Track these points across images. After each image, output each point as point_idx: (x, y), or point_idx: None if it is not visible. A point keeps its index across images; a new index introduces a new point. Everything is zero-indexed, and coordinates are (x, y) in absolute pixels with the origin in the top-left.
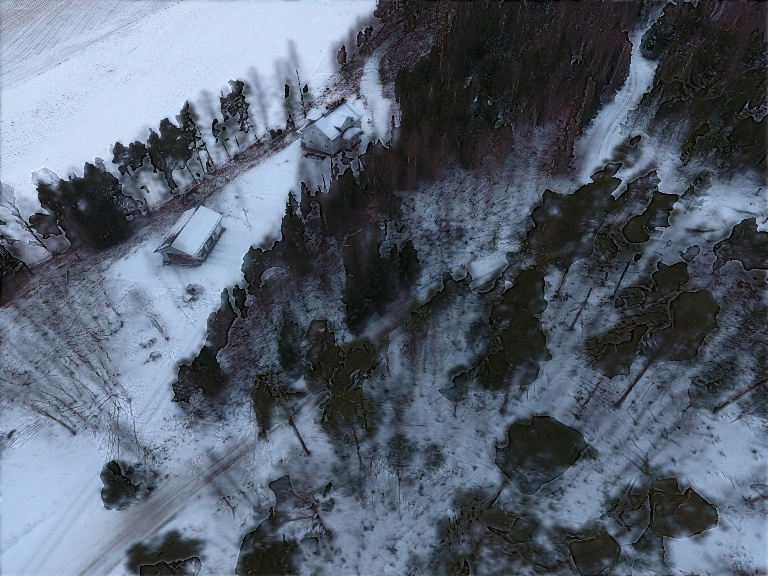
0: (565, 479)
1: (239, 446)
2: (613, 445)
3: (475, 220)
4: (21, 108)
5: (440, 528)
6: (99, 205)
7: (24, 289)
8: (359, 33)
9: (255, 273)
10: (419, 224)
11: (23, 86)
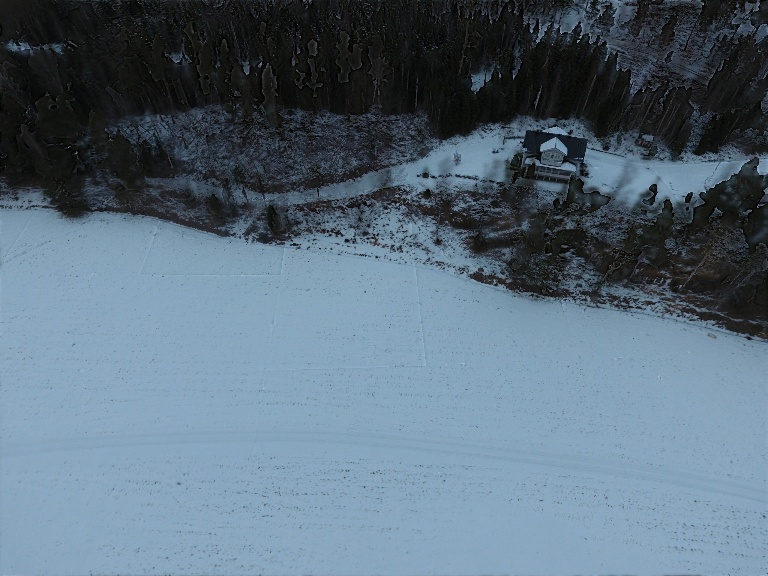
0: None
1: None
2: None
3: None
4: None
5: None
6: None
7: None
8: (215, 198)
9: None
10: None
11: None
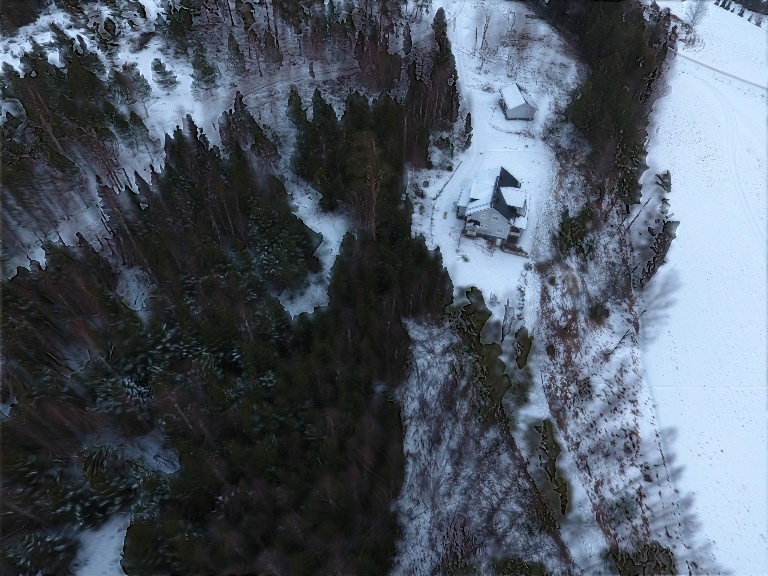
0: None
1: (415, 46)
2: None
3: None
4: None
5: None
6: None
7: None
8: None
9: None
10: None
11: None
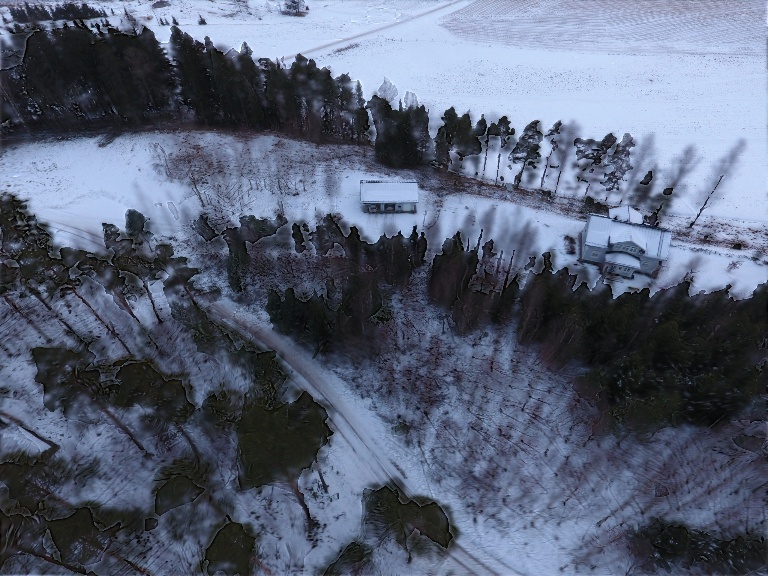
0: (51, 514)
1: None
2: (67, 572)
3: (467, 416)
4: (556, 68)
5: (57, 412)
6: (389, 132)
7: (332, 146)
8: None
9: (320, 233)
10: (447, 355)
11: (587, 56)
